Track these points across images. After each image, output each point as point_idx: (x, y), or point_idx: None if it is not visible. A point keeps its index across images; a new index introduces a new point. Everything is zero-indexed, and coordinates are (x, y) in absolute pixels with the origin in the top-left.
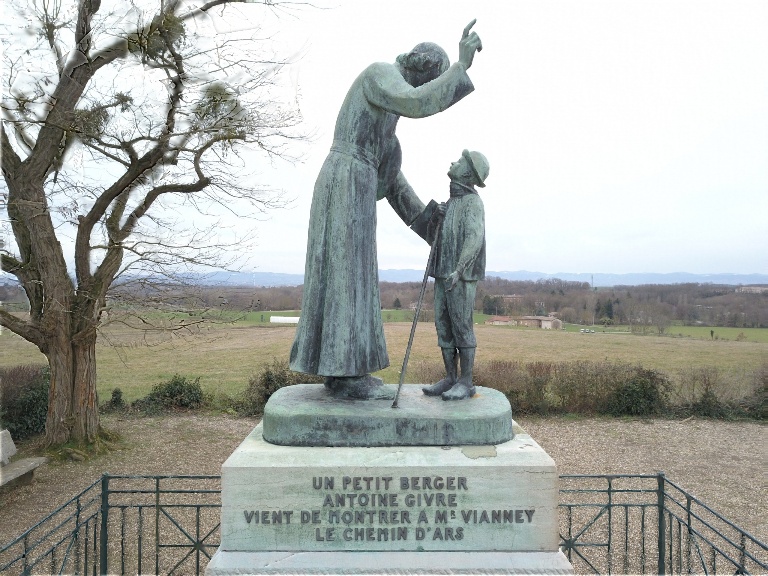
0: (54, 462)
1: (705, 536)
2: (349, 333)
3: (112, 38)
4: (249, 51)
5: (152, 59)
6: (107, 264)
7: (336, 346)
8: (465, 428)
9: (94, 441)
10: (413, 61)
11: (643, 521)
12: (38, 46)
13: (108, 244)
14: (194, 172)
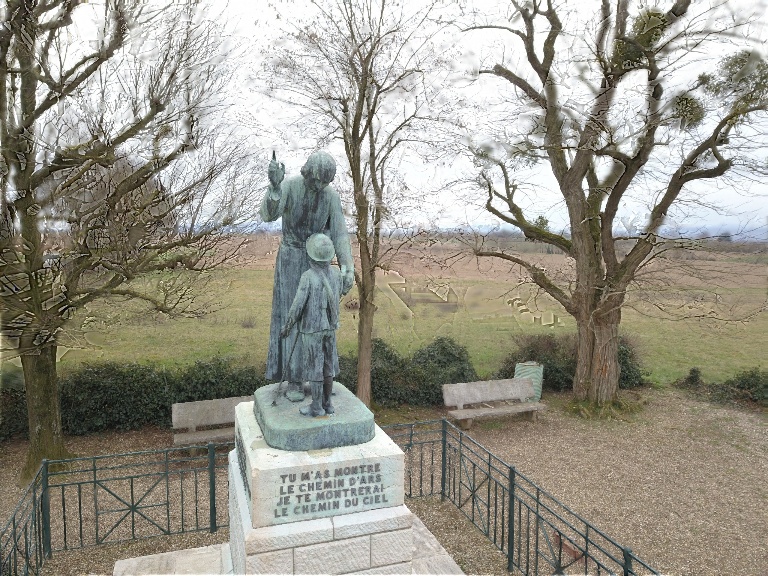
0: (566, 412)
1: None
2: (268, 353)
3: (578, 64)
4: (717, 20)
5: (635, 62)
6: (634, 253)
7: None
8: None
9: (602, 406)
10: None
11: None
12: None
13: (642, 234)
14: (713, 156)
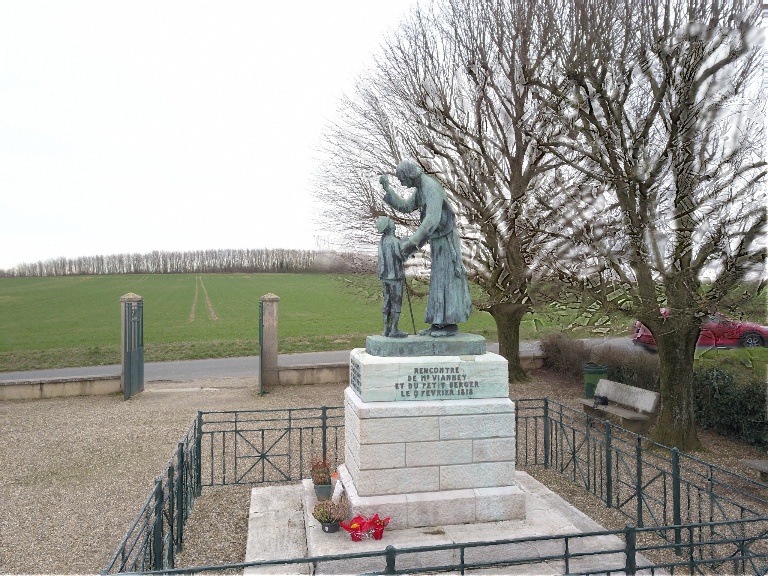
0: None
1: None
2: None
3: None
4: None
5: None
6: None
7: None
8: None
9: None
10: None
11: None
12: None
13: None
14: None
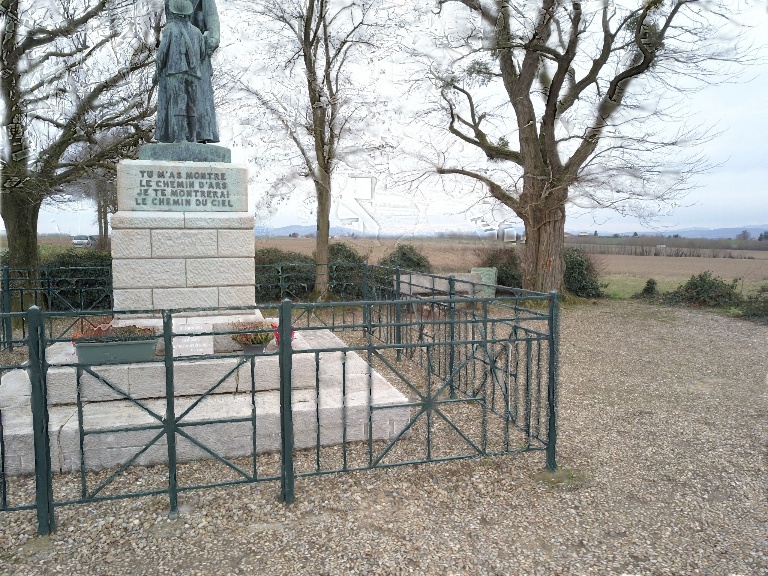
0: (513, 305)
1: None
2: None
3: None
4: None
5: None
6: (576, 154)
7: None
8: None
9: None
10: None
11: None
12: None
13: None
14: (639, 50)
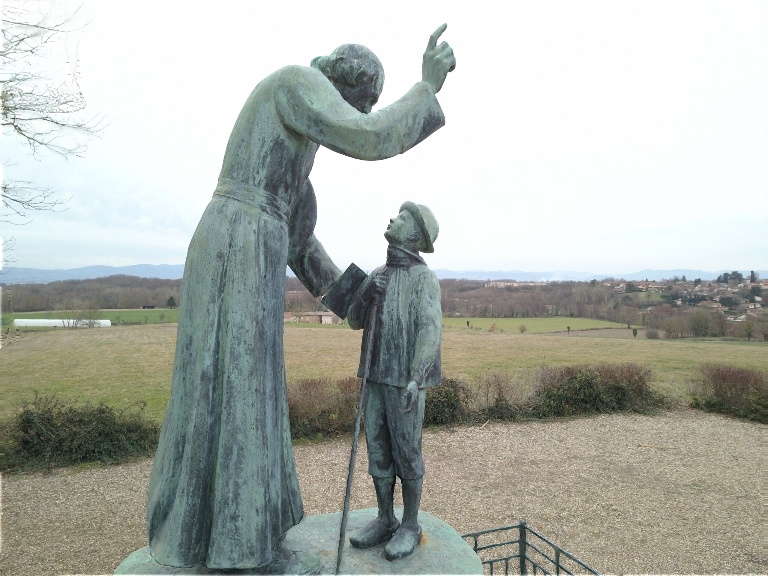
0: None
1: (537, 561)
2: (263, 495)
3: None
4: (4, 7)
5: None
6: None
7: (241, 518)
8: None
9: None
10: (342, 69)
11: (506, 575)
12: None
13: None
14: None
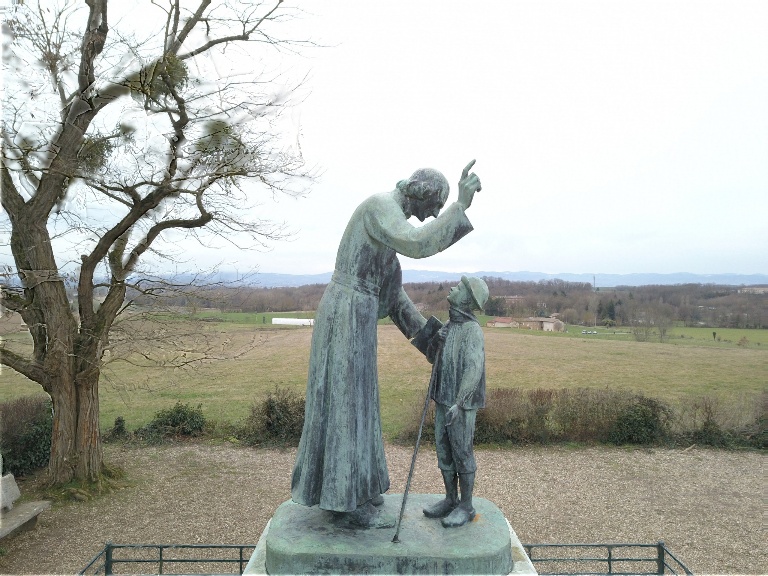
0: (58, 503)
1: None
2: (350, 468)
3: (115, 86)
4: (251, 93)
5: (155, 102)
6: (110, 301)
7: (338, 481)
8: (465, 567)
9: (97, 480)
10: (413, 190)
11: None
12: (41, 91)
13: (111, 280)
14: (196, 208)
